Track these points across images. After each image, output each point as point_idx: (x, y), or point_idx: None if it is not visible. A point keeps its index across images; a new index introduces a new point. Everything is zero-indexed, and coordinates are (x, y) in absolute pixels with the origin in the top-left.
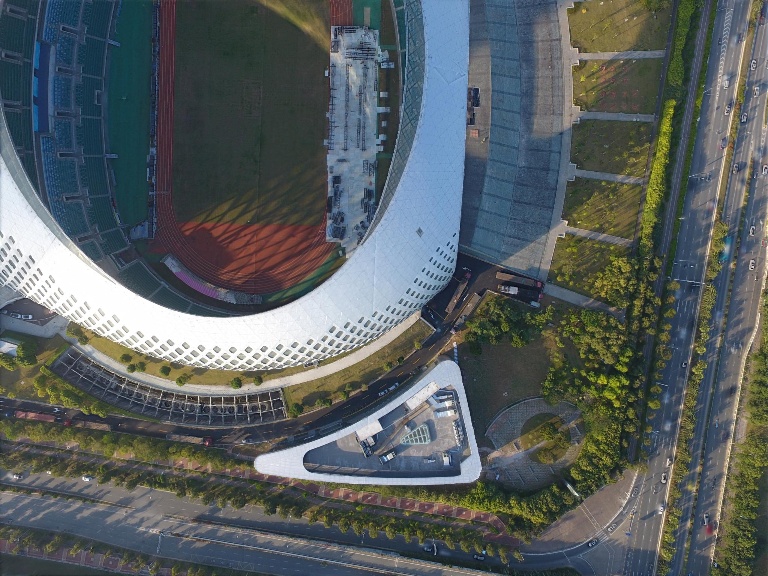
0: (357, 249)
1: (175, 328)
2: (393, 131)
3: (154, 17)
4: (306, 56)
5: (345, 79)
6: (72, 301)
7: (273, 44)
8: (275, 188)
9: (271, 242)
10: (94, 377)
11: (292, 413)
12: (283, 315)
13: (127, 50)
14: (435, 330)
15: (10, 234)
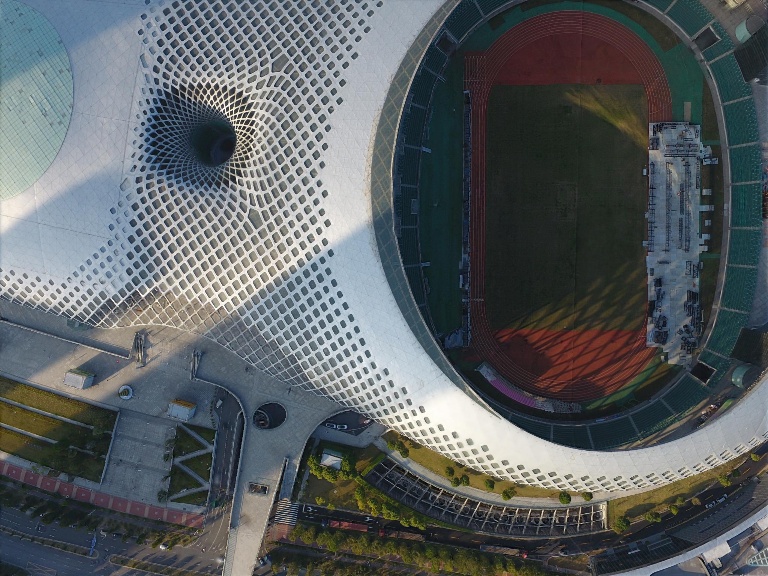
0: (763, 383)
1: (552, 460)
2: (717, 230)
3: (466, 122)
4: (623, 155)
5: (665, 178)
6: (437, 429)
7: (588, 144)
8: (592, 292)
9: (589, 348)
10: (404, 485)
11: (620, 528)
12: (671, 448)
13: (437, 156)
14: (767, 439)
15: (386, 366)
